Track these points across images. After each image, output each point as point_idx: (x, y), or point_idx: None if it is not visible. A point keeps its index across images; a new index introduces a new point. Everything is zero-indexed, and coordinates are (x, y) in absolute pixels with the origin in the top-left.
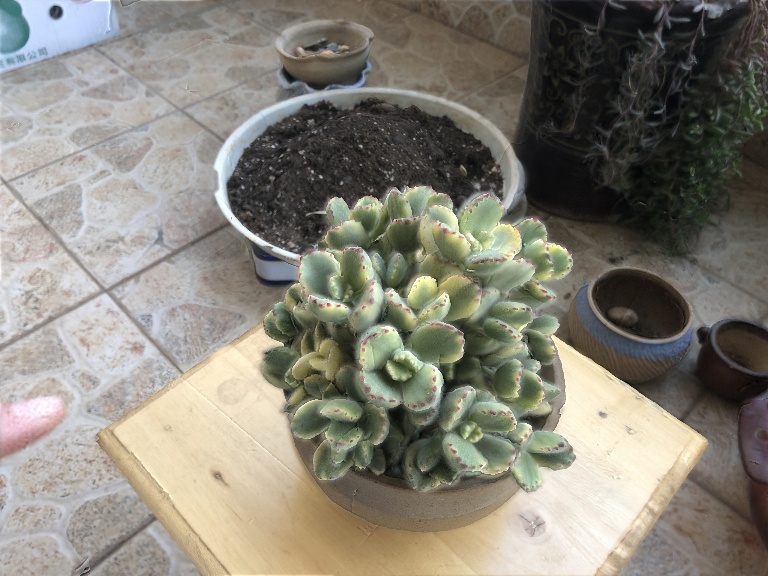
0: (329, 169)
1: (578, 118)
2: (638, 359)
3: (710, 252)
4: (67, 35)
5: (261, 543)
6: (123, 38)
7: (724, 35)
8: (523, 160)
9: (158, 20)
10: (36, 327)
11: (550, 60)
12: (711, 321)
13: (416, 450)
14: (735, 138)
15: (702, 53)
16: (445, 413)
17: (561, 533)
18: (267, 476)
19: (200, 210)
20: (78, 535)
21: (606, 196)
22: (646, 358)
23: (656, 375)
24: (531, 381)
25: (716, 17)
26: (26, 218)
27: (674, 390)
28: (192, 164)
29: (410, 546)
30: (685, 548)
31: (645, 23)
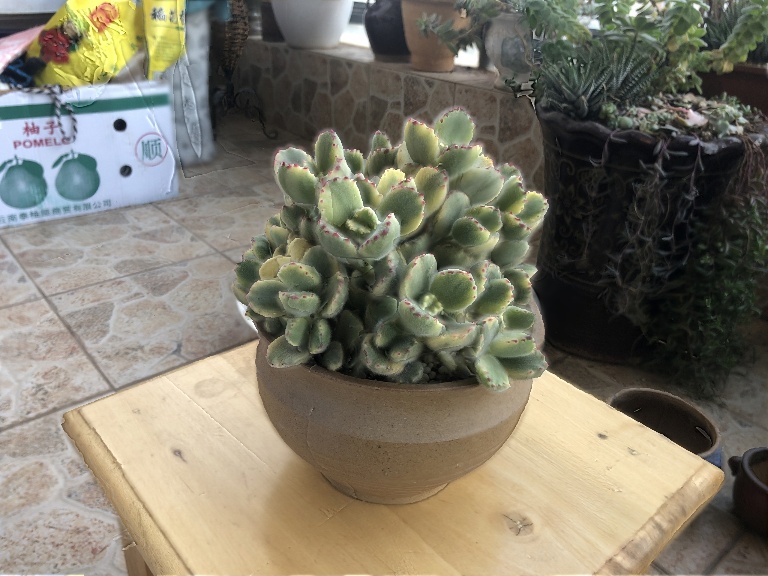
0: None
1: (591, 253)
2: None
3: (739, 398)
4: (131, 191)
5: (209, 514)
6: (180, 200)
7: (724, 176)
8: (539, 293)
9: (214, 189)
10: (38, 416)
11: (562, 199)
12: None
13: (374, 334)
14: (748, 275)
15: (705, 191)
16: (402, 273)
17: (551, 535)
18: (229, 458)
19: (222, 329)
20: None
21: (624, 332)
22: None
23: None
24: (500, 285)
25: (712, 153)
26: (56, 325)
27: (709, 526)
28: (222, 293)
29: (375, 531)
30: None
31: (645, 154)
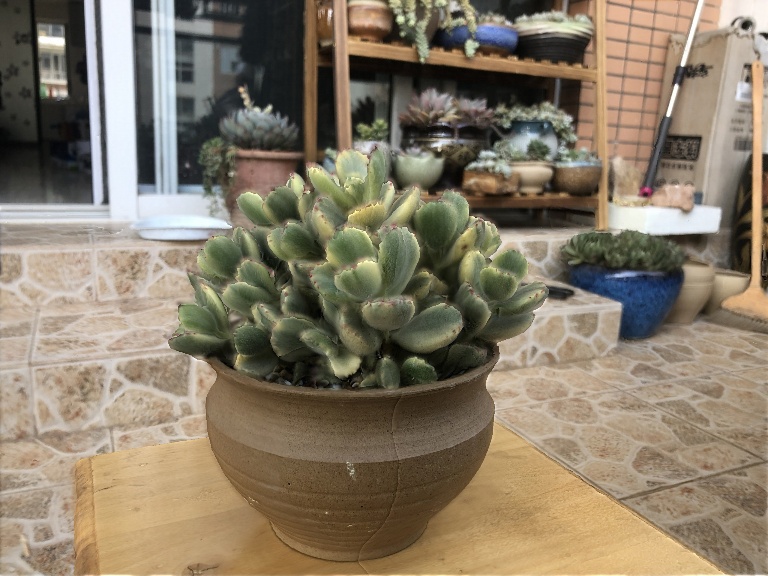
0: None
1: None
2: None
3: None
4: None
5: None
6: None
7: None
8: None
9: None
10: None
11: None
12: None
13: None
14: None
15: None
16: None
17: None
18: None
19: None
20: None
21: None
22: None
23: None
24: None
25: None
26: None
27: None
28: None
29: None
30: None
31: None
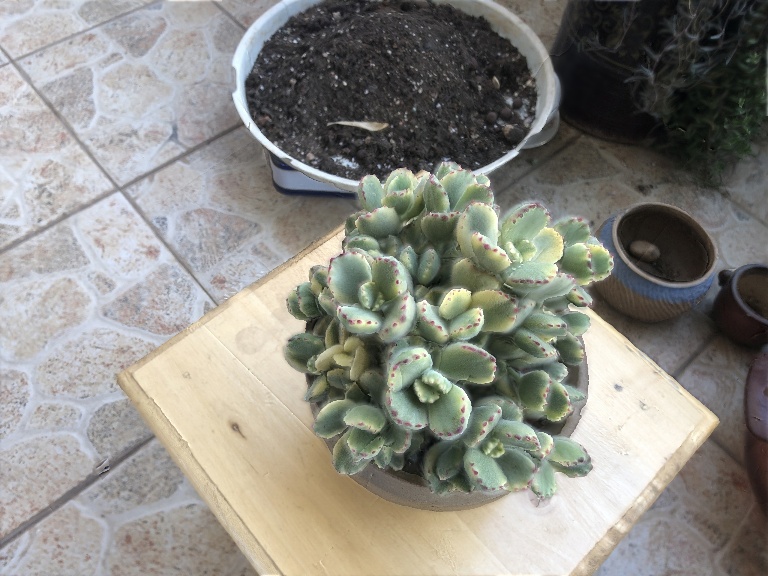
0: (354, 75)
1: (626, 33)
2: (655, 301)
3: (744, 185)
4: None
5: (276, 497)
6: None
7: None
8: (561, 75)
9: None
10: (50, 224)
11: None
12: (734, 260)
13: (436, 455)
14: None
15: None
16: (469, 433)
17: (565, 506)
18: (283, 431)
19: (216, 105)
20: (98, 436)
21: (644, 120)
22: (664, 300)
23: (671, 317)
24: (557, 393)
25: None
26: (35, 103)
27: (686, 330)
28: (208, 51)
29: (418, 509)
30: (675, 486)
31: None
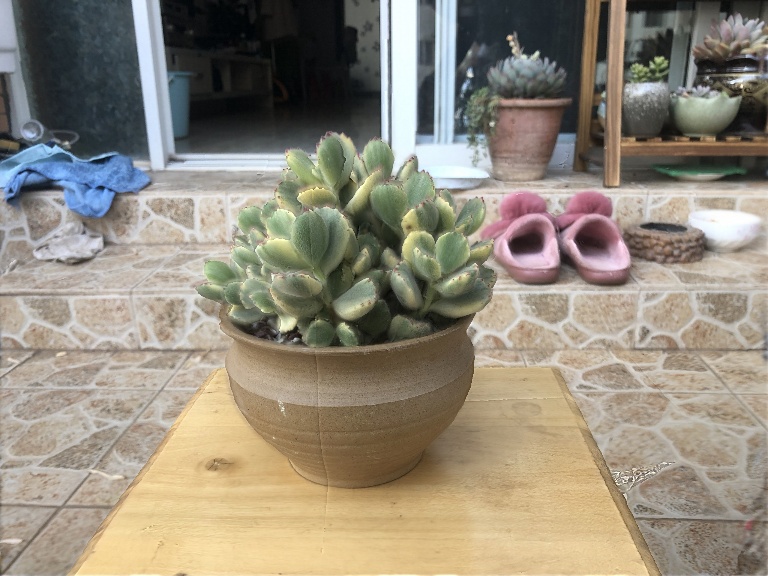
0: None
1: None
2: None
3: None
4: None
5: None
6: None
7: None
8: None
9: None
10: None
11: None
12: None
13: None
14: None
15: None
16: None
17: (190, 471)
18: None
19: None
20: None
21: None
22: None
23: None
24: None
25: None
26: None
27: None
28: None
29: None
30: None
31: None
